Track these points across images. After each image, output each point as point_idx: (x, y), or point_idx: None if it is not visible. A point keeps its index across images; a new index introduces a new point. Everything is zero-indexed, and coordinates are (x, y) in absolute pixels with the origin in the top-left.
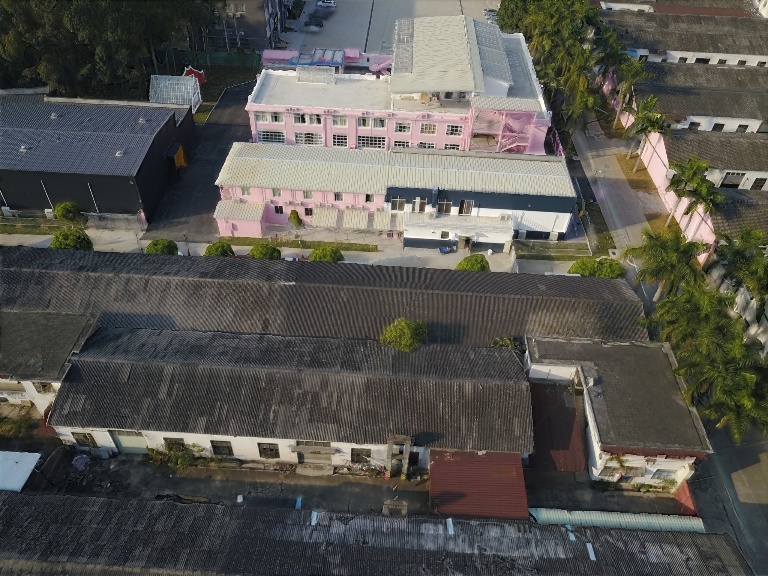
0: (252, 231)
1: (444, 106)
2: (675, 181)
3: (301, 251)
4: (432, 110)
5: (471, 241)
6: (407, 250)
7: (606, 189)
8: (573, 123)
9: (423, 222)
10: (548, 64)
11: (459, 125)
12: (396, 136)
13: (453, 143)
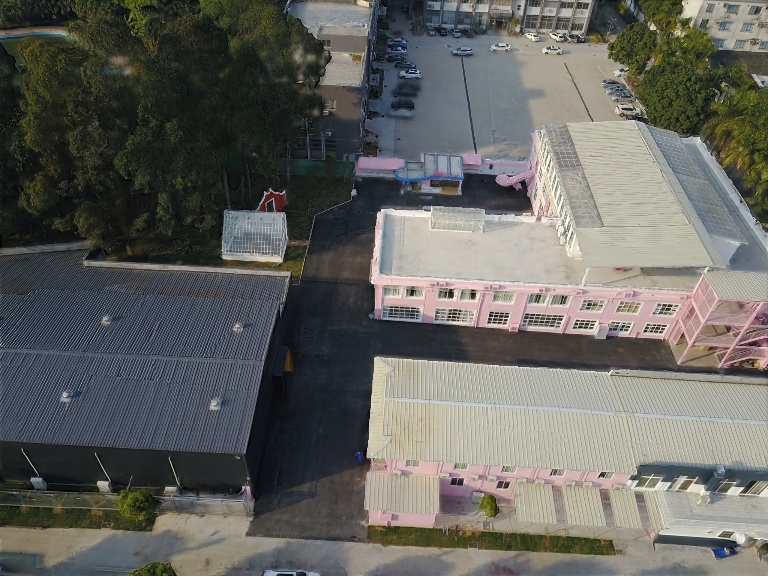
0: (420, 520)
1: (647, 272)
2: None
3: (499, 557)
4: (633, 280)
5: (765, 542)
6: (660, 550)
7: None
8: None
9: (692, 514)
10: (767, 197)
11: (674, 304)
12: (580, 314)
13: (659, 323)
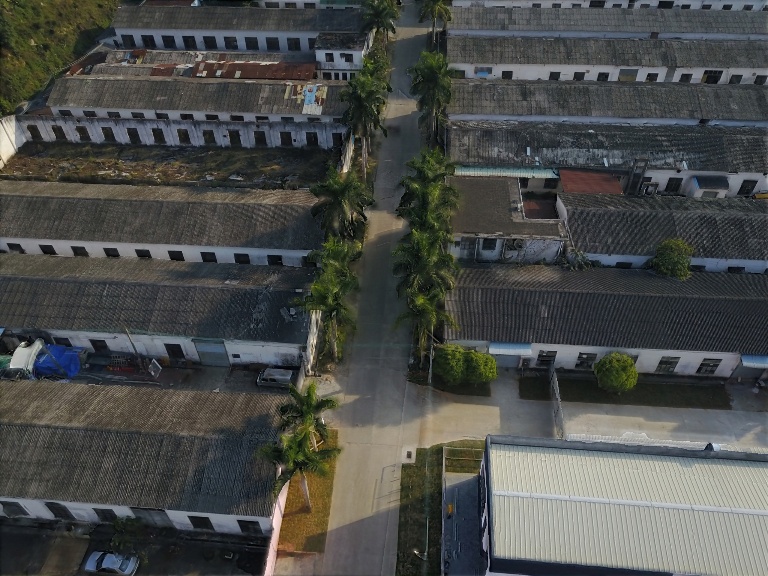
0: None
1: None
2: (324, 454)
3: None
4: None
5: None
6: None
7: None
8: None
9: None
10: None
11: None
12: None
13: None
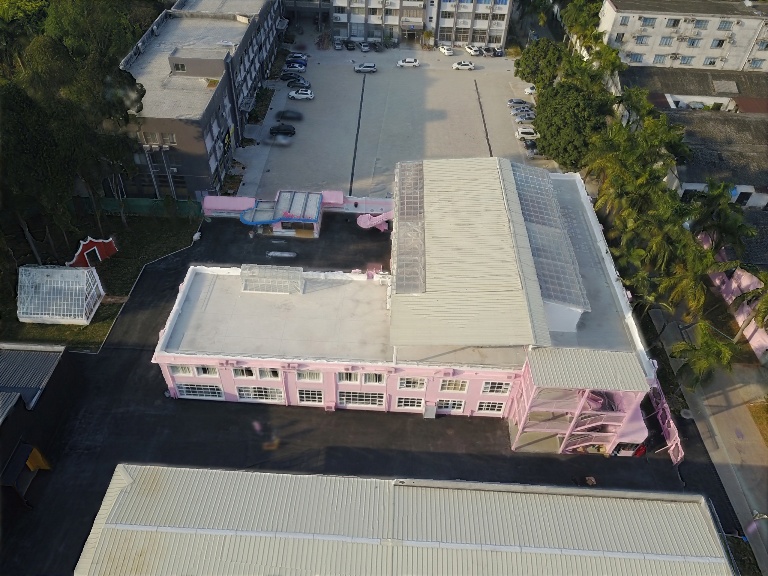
0: None
1: None
2: None
3: None
4: (459, 354)
5: None
6: None
7: (752, 498)
8: (692, 381)
9: None
10: (632, 248)
11: (504, 382)
12: (401, 392)
13: (493, 401)
